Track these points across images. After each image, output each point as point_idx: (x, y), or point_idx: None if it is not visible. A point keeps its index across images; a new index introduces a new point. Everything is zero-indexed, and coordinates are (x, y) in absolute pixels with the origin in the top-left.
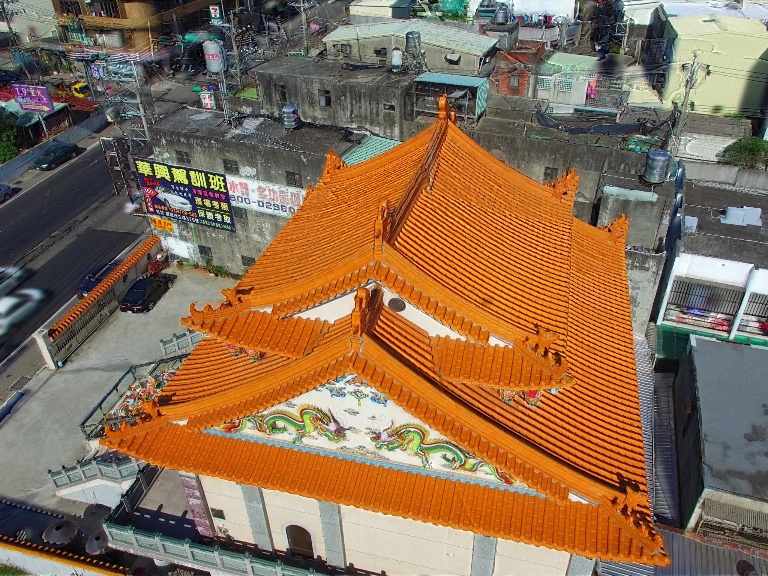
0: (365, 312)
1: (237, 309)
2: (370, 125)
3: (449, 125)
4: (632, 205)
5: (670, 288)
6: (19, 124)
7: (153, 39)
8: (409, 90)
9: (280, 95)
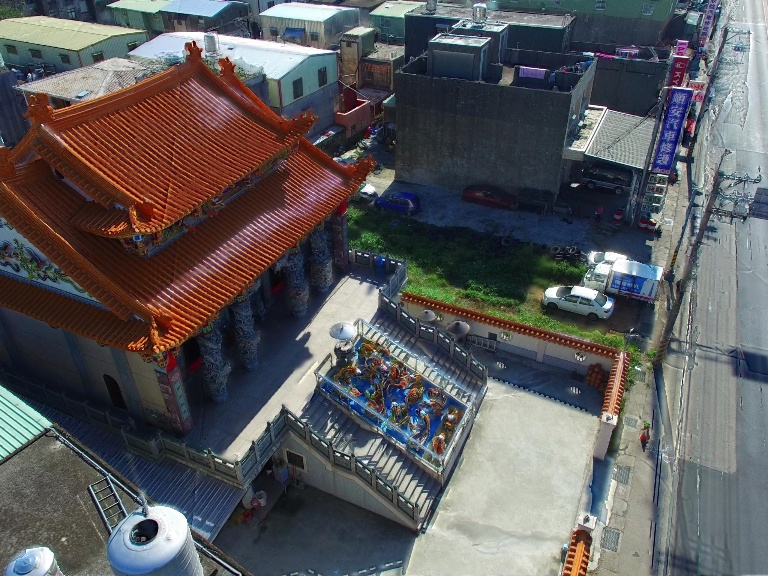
0: None
1: None
2: None
3: None
4: None
5: None
6: None
7: None
8: None
9: None
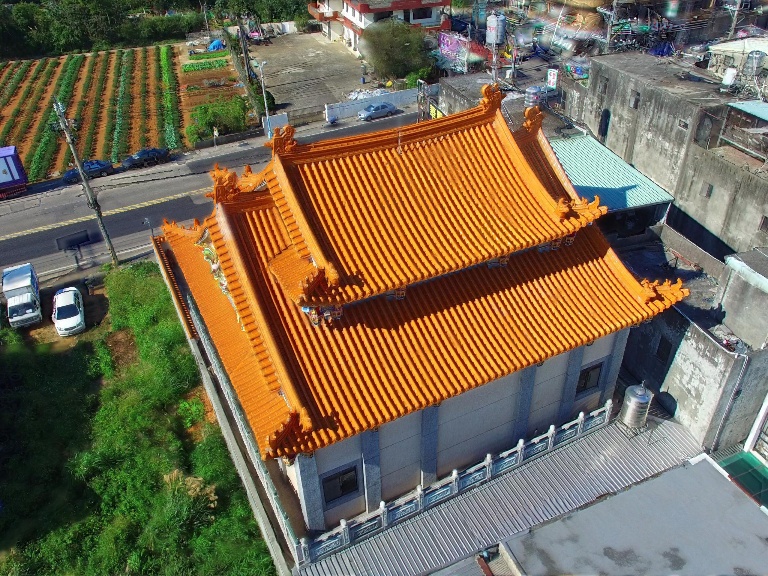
0: (226, 189)
1: (242, 180)
2: (662, 138)
3: (497, 114)
4: (751, 290)
5: (764, 411)
6: (440, 65)
7: (562, 16)
8: (714, 112)
9: (603, 87)
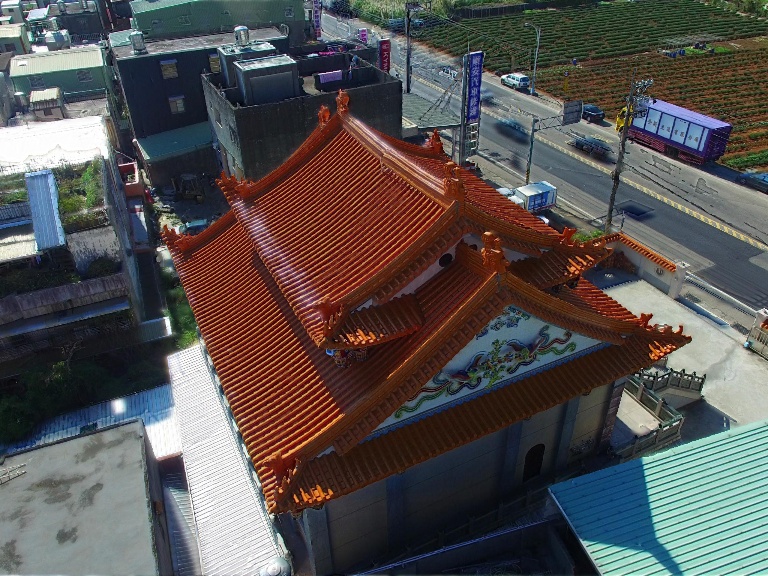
0: None
1: None
2: None
3: None
4: None
5: None
6: None
7: None
8: None
9: None
